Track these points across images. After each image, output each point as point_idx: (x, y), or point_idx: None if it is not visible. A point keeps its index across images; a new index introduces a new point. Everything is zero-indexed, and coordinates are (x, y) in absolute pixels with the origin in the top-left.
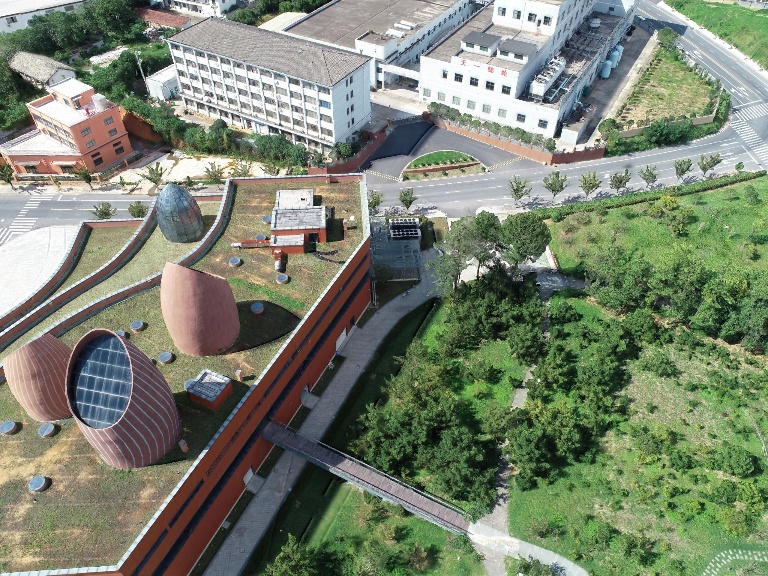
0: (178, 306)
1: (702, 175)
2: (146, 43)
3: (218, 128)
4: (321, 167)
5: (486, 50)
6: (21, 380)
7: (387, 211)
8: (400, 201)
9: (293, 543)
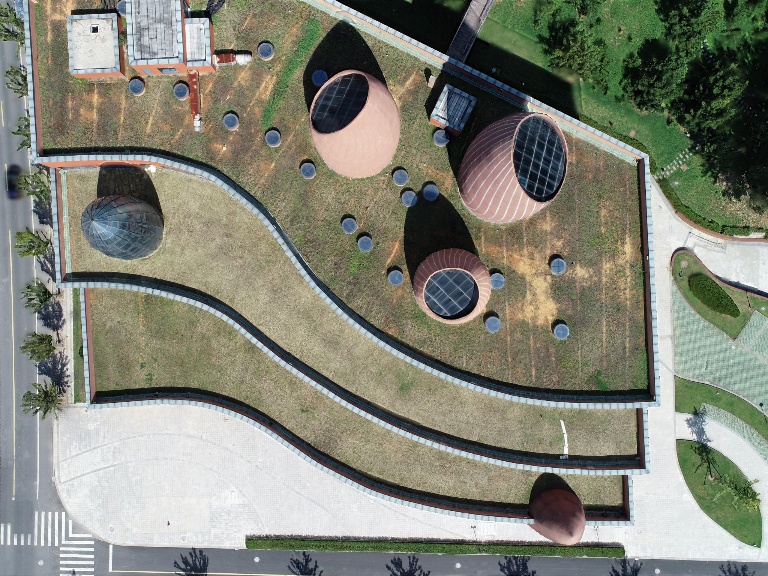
0: (392, 122)
1: None
2: None
3: None
4: None
5: None
6: (489, 289)
7: None
8: None
9: (561, 51)
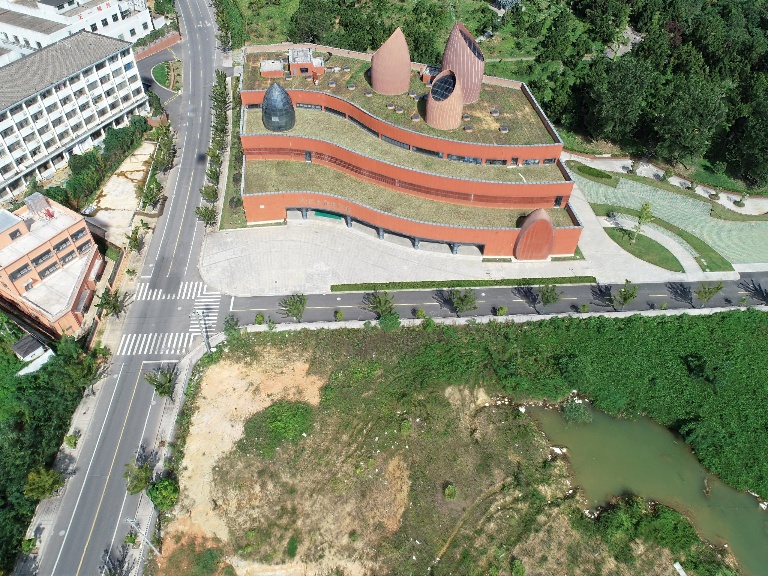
0: None
1: (209, 1)
2: None
3: (86, 159)
4: (163, 114)
5: (73, 3)
6: None
7: None
8: (207, 93)
9: None
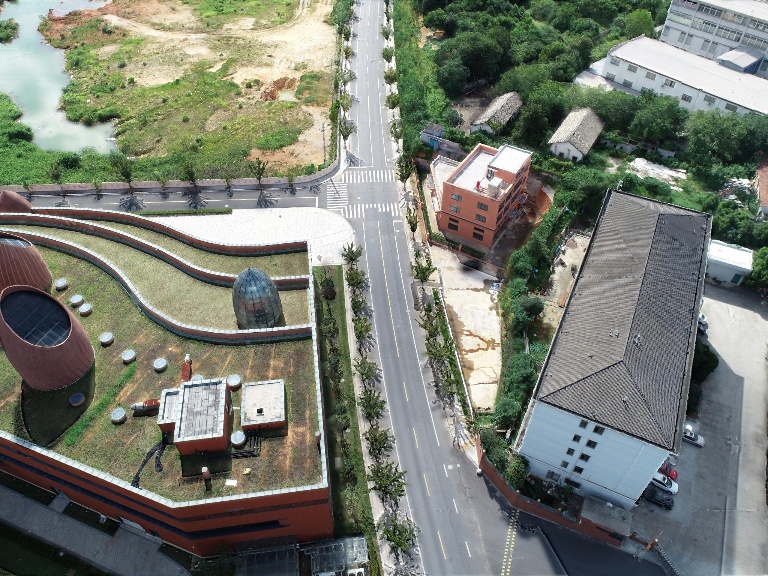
0: None
1: None
2: (709, 189)
3: (522, 305)
4: None
5: None
6: None
7: (414, 569)
8: None
9: None
